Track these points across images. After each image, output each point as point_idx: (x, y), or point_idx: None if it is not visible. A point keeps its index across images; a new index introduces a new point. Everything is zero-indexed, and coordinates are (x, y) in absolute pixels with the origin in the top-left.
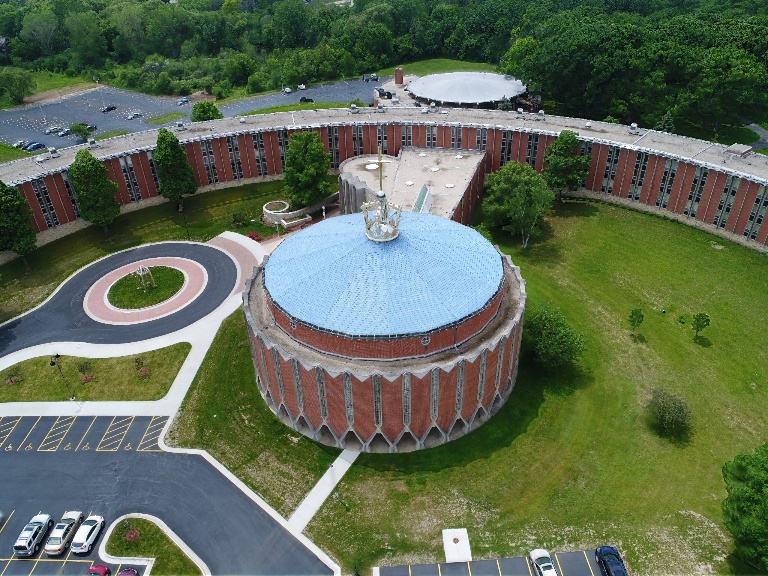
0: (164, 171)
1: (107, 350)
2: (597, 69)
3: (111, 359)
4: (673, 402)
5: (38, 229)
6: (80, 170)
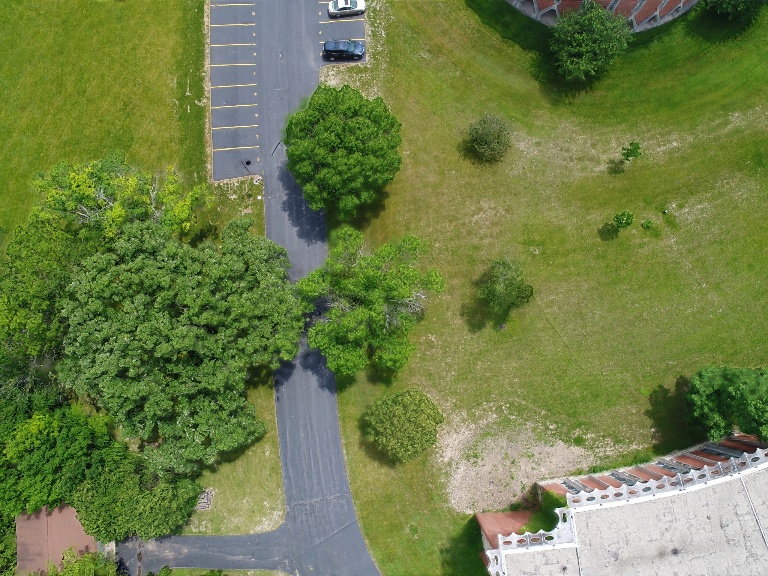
0: None
1: None
2: None
3: None
4: (486, 126)
5: None
6: None
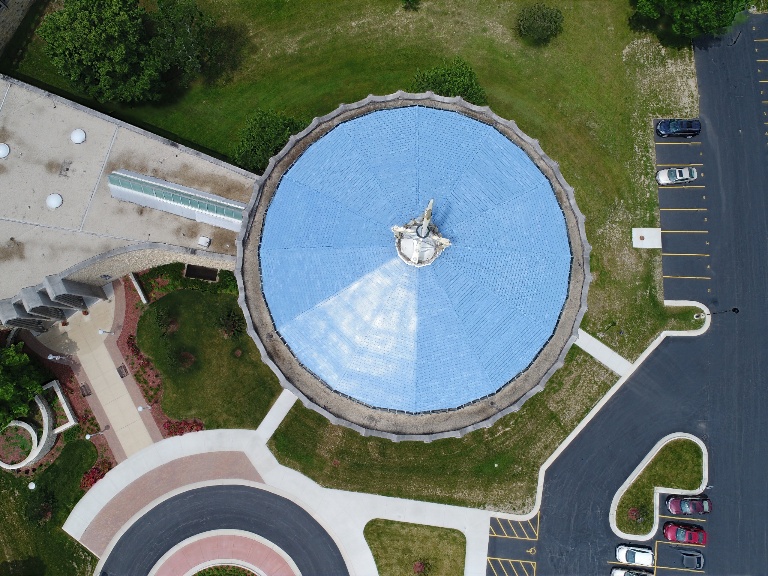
0: None
1: None
2: None
3: None
4: (550, 14)
5: None
6: None
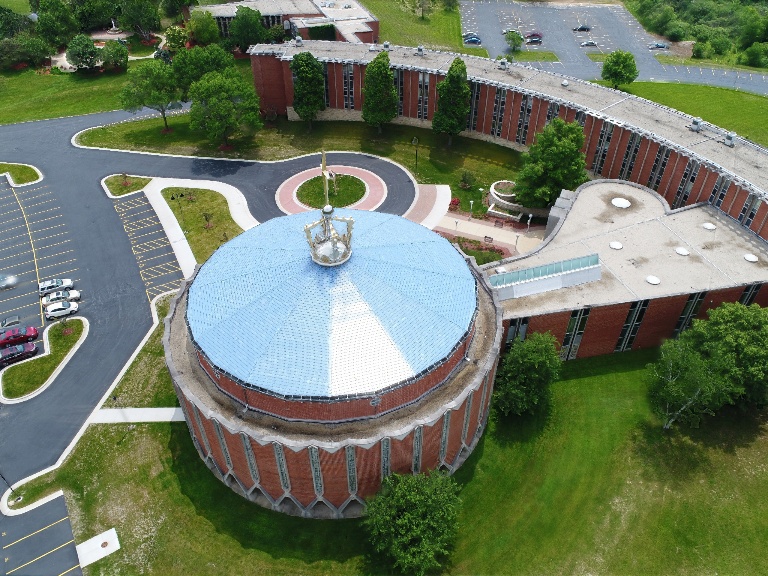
0: (440, 101)
1: (243, 217)
2: None
3: (234, 224)
4: None
5: (336, 105)
6: (370, 69)
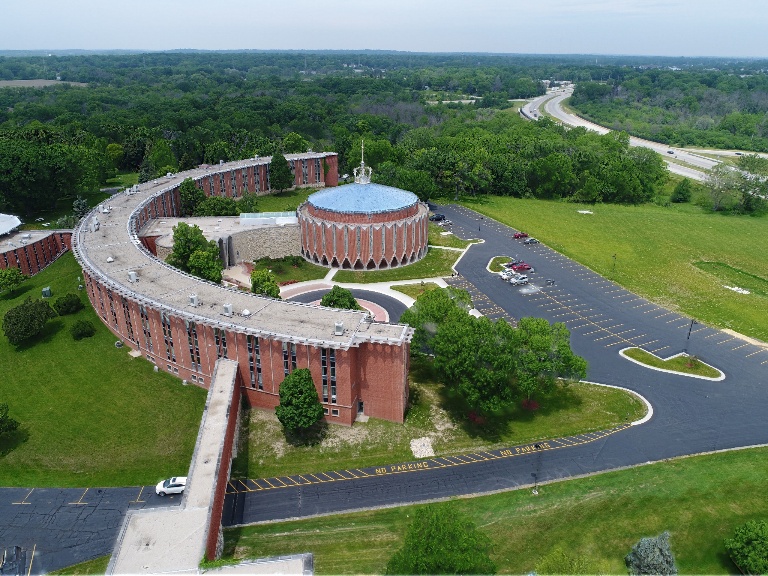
0: None
1: None
2: (64, 167)
3: None
4: None
5: None
6: None
